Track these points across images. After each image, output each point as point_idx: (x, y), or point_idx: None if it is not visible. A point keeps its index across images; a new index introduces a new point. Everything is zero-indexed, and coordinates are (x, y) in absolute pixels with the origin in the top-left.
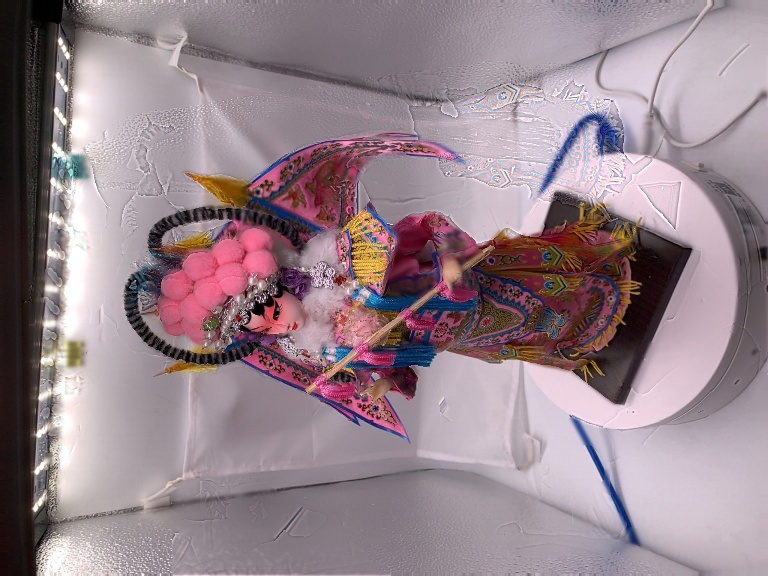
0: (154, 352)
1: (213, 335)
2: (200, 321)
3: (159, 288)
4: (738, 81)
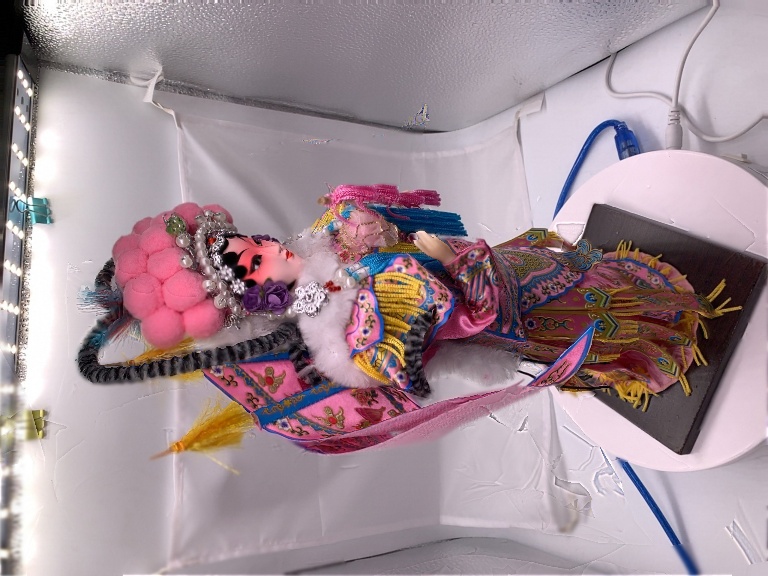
0: (136, 388)
1: (186, 239)
2: (163, 230)
3: (117, 299)
4: (529, 223)
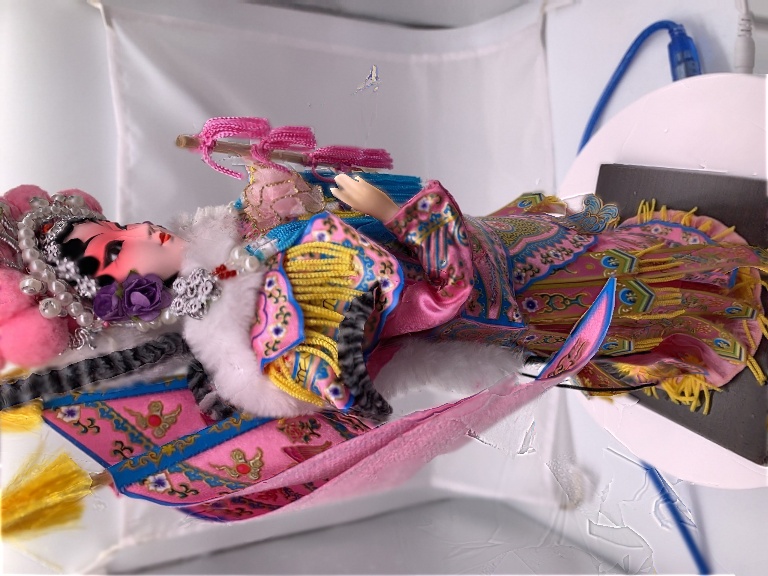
0: None
1: None
2: None
3: None
4: None
